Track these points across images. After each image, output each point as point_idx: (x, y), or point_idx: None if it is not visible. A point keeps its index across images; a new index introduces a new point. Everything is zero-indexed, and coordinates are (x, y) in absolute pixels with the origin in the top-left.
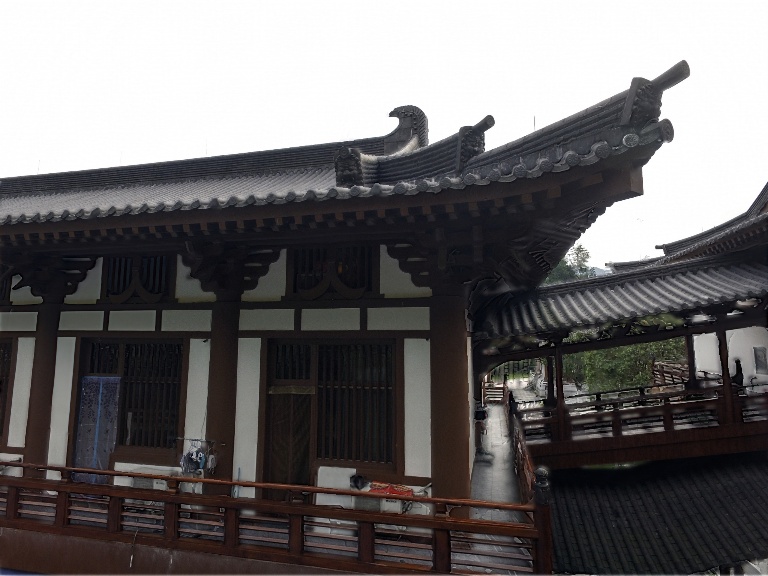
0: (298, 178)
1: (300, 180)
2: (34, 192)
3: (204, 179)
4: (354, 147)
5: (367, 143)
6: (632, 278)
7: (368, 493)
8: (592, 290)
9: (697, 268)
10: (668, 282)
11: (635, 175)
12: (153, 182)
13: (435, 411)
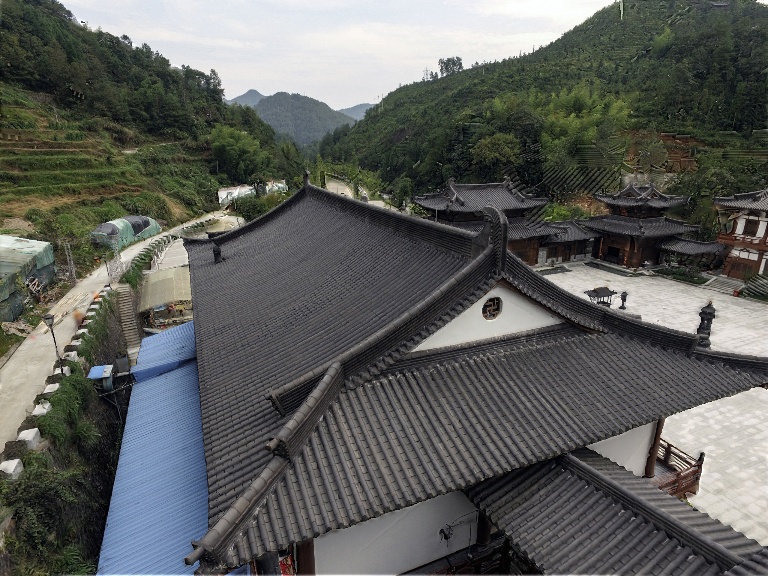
0: (414, 262)
1: (408, 270)
2: (336, 207)
3: (388, 230)
4: (455, 238)
5: (462, 238)
6: (648, 516)
7: (255, 569)
8: (606, 495)
9: (728, 569)
10: (676, 555)
11: (212, 575)
12: (370, 221)
13: (296, 553)
